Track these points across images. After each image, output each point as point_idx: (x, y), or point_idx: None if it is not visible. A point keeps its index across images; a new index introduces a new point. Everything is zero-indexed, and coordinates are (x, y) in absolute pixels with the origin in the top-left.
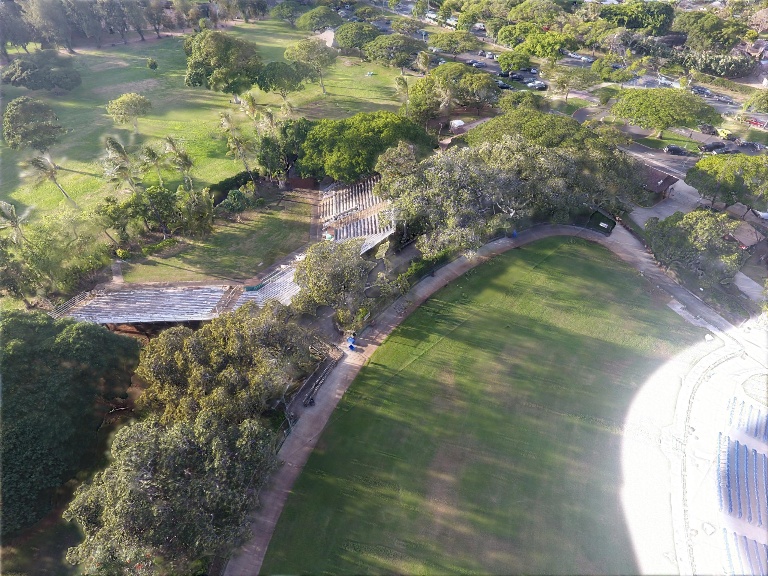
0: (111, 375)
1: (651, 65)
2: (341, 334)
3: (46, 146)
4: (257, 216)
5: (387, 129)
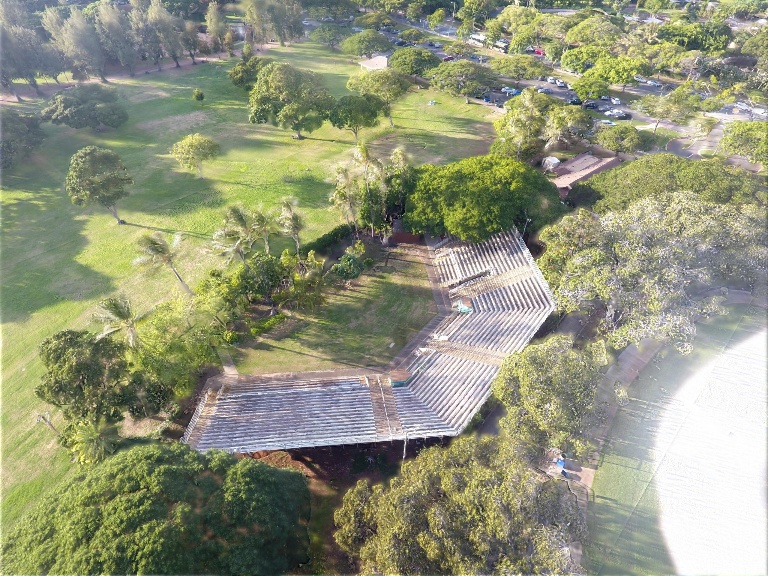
0: (290, 535)
1: (743, 93)
2: (540, 452)
3: (115, 201)
4: (367, 280)
5: (516, 180)
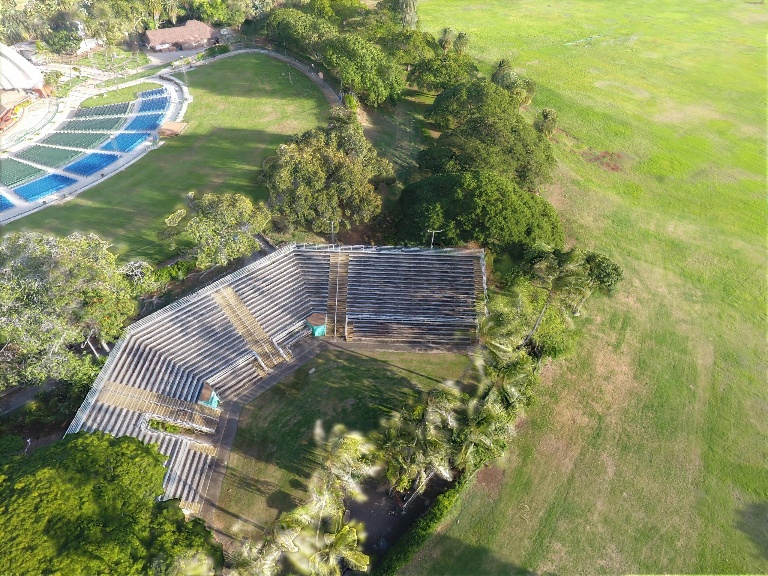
0: None
1: None
2: None
3: None
4: (318, 478)
5: None
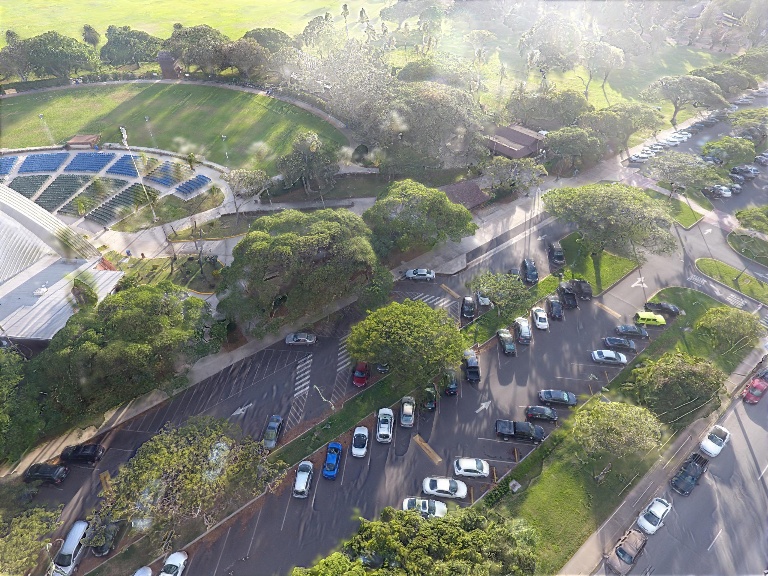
0: None
1: None
2: None
3: None
4: None
5: (427, 65)
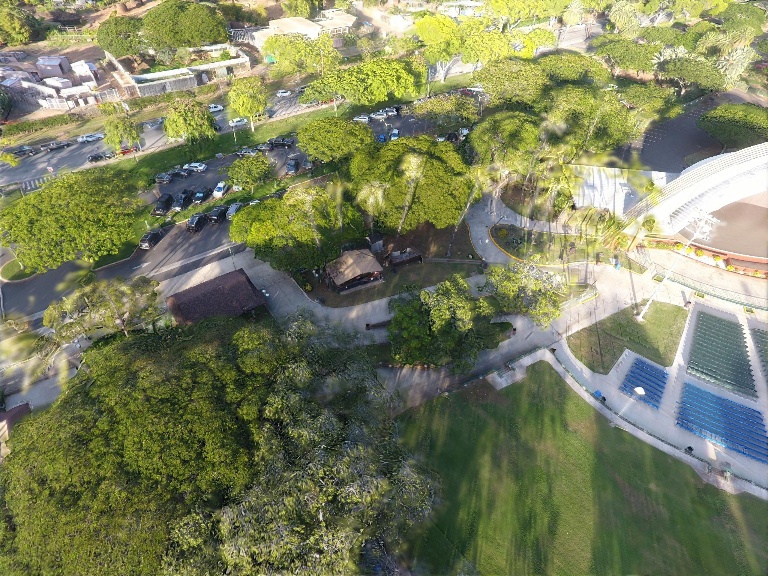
0: None
1: None
2: None
3: None
4: None
5: None
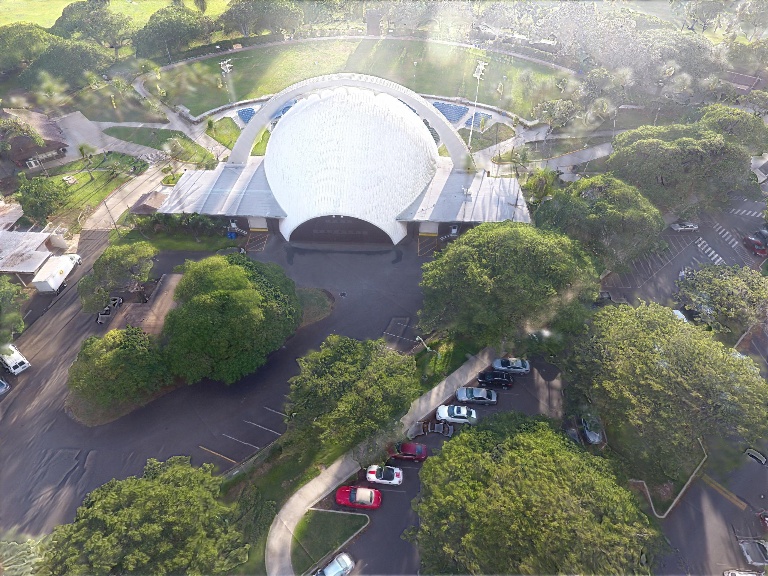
0: None
1: None
2: None
3: None
4: None
5: (633, 18)
